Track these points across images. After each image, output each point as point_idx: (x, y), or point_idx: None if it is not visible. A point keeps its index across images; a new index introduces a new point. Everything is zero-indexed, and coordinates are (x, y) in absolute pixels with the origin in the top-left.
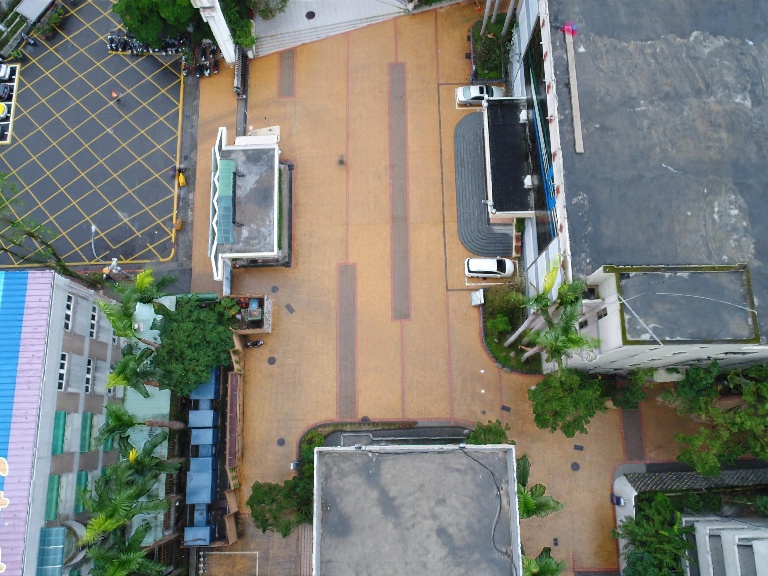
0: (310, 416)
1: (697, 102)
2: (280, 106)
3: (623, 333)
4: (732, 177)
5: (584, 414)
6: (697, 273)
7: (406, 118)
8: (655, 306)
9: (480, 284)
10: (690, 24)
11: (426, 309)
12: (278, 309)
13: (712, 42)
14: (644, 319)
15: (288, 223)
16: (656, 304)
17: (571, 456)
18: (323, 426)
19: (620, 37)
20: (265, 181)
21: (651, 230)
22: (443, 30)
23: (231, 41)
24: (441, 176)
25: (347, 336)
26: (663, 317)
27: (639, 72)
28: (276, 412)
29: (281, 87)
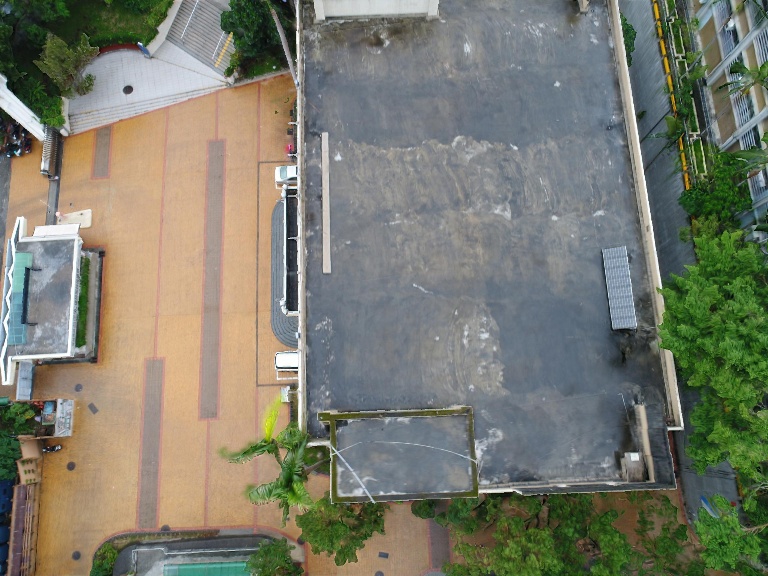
0: (108, 526)
1: (454, 214)
2: (93, 188)
3: (333, 489)
4: (485, 297)
5: (349, 543)
6: (419, 418)
7: (223, 199)
8: (371, 456)
9: (291, 378)
10: (453, 128)
11: (234, 406)
12: (80, 409)
13: (475, 148)
14: (358, 471)
15: (96, 315)
16: (372, 454)
17: (375, 564)
18: (120, 538)
19: (379, 143)
20: (63, 275)
21: (396, 358)
22: (266, 104)
23: (36, 122)
24: (256, 262)
25: (151, 437)
26: (379, 469)
27: (396, 182)
28: (72, 523)
29: (95, 167)
